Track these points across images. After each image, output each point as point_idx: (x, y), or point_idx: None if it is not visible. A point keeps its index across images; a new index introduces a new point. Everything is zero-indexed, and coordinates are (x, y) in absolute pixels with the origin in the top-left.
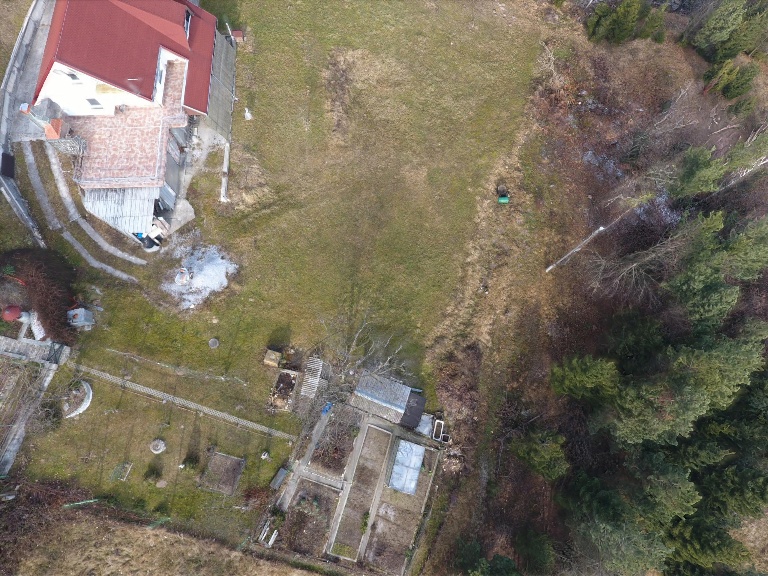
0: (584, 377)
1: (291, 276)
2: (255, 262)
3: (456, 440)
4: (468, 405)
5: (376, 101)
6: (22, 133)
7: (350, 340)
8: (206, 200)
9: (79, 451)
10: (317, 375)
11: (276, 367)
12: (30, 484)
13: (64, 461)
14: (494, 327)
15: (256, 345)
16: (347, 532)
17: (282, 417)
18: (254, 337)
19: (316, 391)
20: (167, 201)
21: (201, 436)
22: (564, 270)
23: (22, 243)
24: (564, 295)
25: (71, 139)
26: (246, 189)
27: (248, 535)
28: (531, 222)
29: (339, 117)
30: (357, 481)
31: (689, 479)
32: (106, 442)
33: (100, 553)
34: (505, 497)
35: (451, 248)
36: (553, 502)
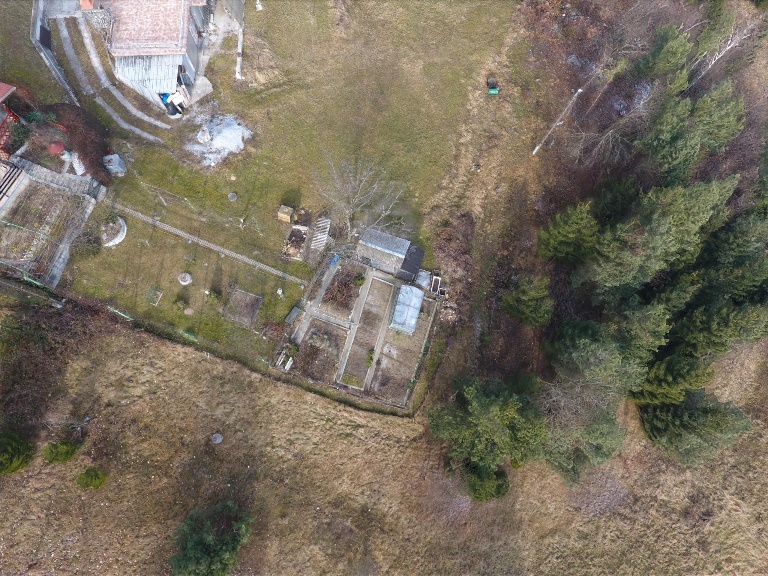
0: (566, 226)
1: (300, 146)
2: (268, 131)
3: (452, 296)
4: (463, 267)
5: (375, 4)
6: (57, 11)
7: (355, 206)
8: (223, 77)
9: (116, 276)
10: (325, 232)
11: (288, 223)
12: (74, 300)
13: (103, 284)
14: (486, 201)
15: (270, 203)
16: (355, 365)
17: (295, 265)
18: (268, 195)
19: (325, 245)
20: (188, 73)
21: (223, 274)
22: (549, 153)
23: (60, 102)
24: (550, 175)
25: (103, 9)
26: (259, 69)
27: (266, 361)
28: (519, 111)
29: (342, 14)
30: (363, 323)
31: (665, 335)
32: (140, 271)
33: (137, 364)
34: (497, 350)
35: (446, 130)
36: (541, 356)
